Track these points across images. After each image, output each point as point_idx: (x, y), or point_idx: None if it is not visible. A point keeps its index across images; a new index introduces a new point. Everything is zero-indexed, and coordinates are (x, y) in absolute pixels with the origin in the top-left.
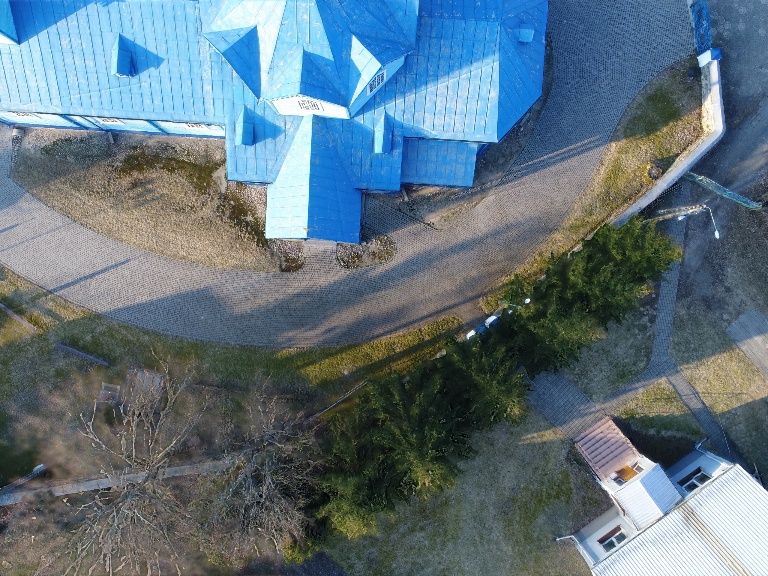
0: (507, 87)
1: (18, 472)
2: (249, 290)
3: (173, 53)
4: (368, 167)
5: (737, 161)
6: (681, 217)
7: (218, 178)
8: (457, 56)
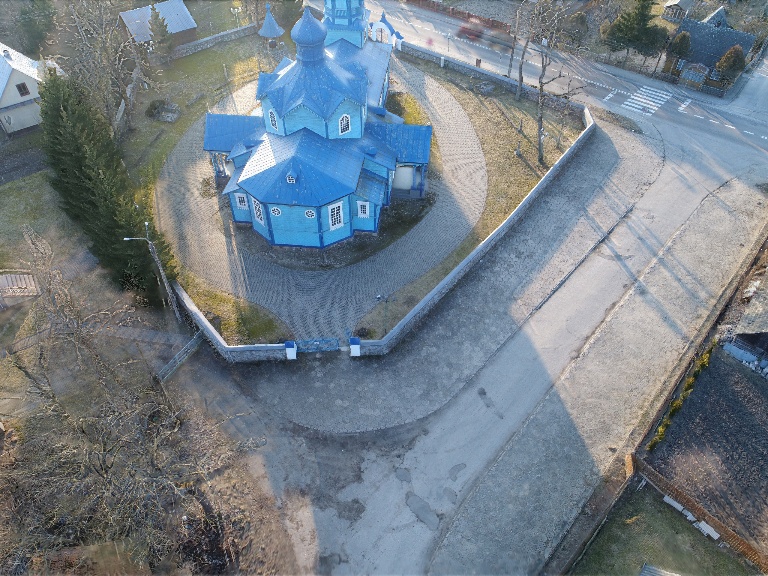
0: (264, 176)
1: None
2: None
3: None
4: None
5: (204, 378)
6: (147, 223)
7: None
8: None
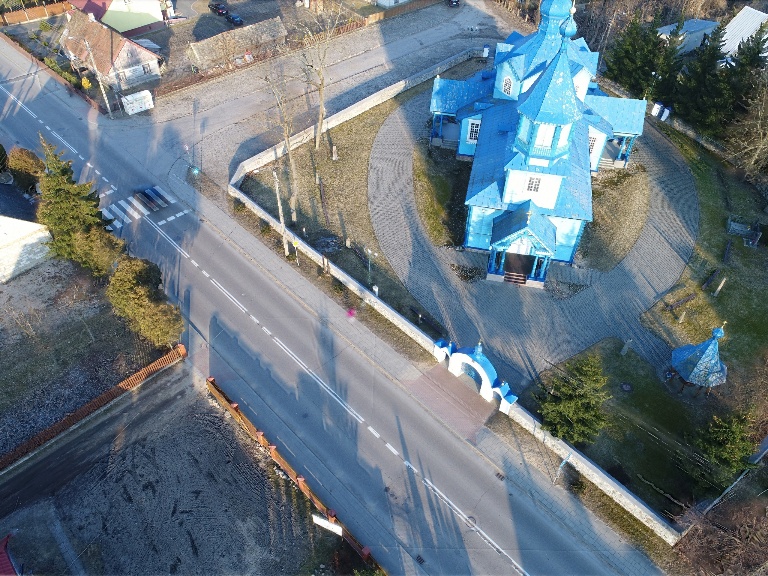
0: None
1: None
2: None
3: None
4: None
5: None
6: None
7: None
8: None
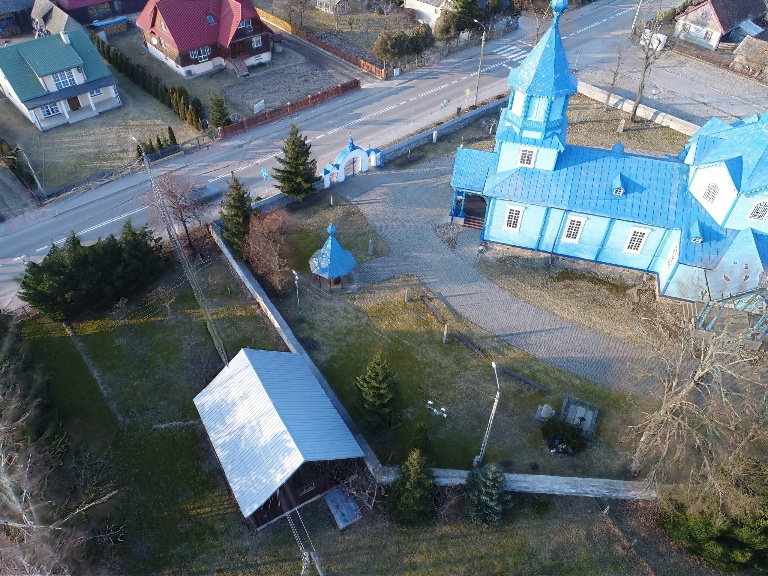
0: None
1: (452, 463)
2: None
3: (653, 186)
4: None
5: None
6: None
7: (631, 294)
8: None
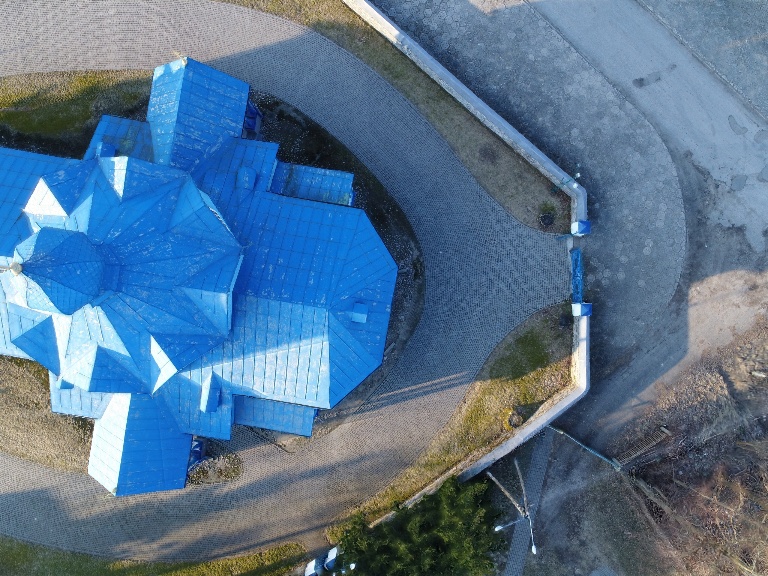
0: (339, 362)
1: None
2: (87, 495)
3: None
4: (197, 416)
5: (604, 413)
6: (498, 528)
7: None
8: (285, 332)
